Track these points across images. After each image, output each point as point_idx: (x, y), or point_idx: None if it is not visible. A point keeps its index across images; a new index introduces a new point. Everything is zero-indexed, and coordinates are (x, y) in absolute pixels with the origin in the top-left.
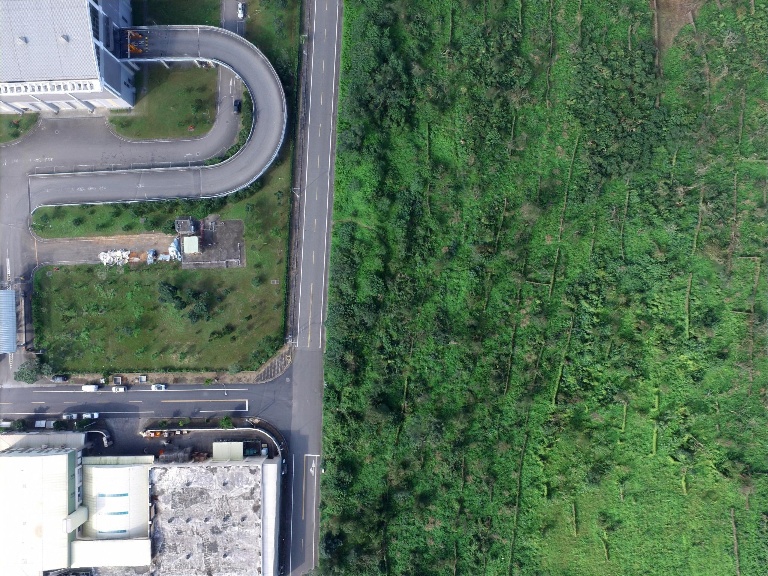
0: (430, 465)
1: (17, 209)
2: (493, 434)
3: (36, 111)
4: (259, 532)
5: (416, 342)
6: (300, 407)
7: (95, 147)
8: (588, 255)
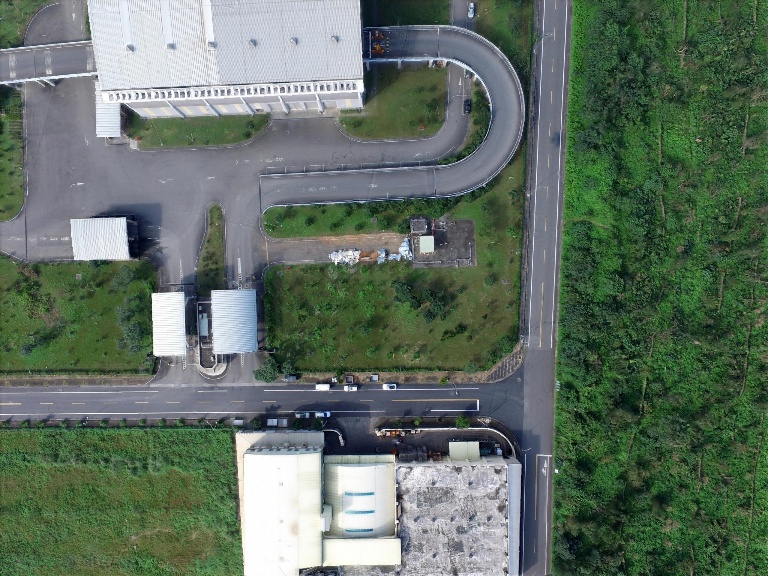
0: (666, 466)
1: (248, 209)
2: (727, 435)
3: (267, 112)
4: (505, 532)
5: (655, 342)
6: (532, 407)
7: (325, 147)
8: None
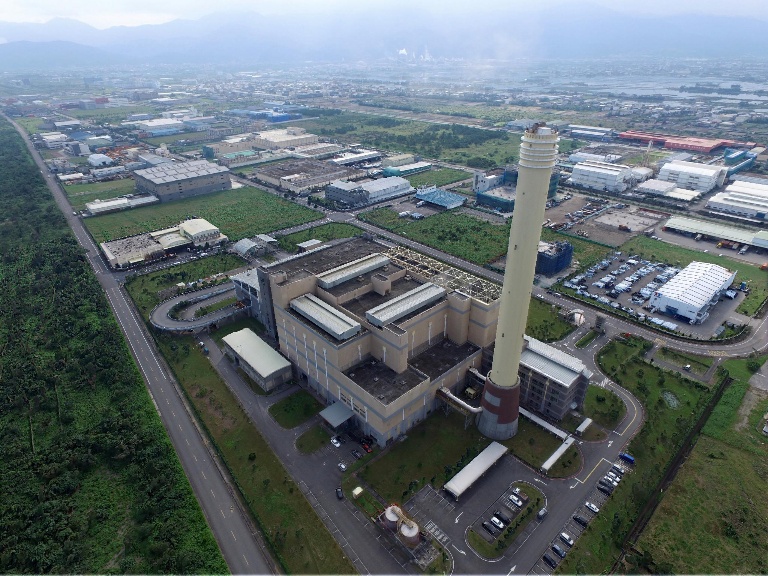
0: None
1: None
2: None
3: None
4: (111, 249)
5: None
6: None
7: None
8: None
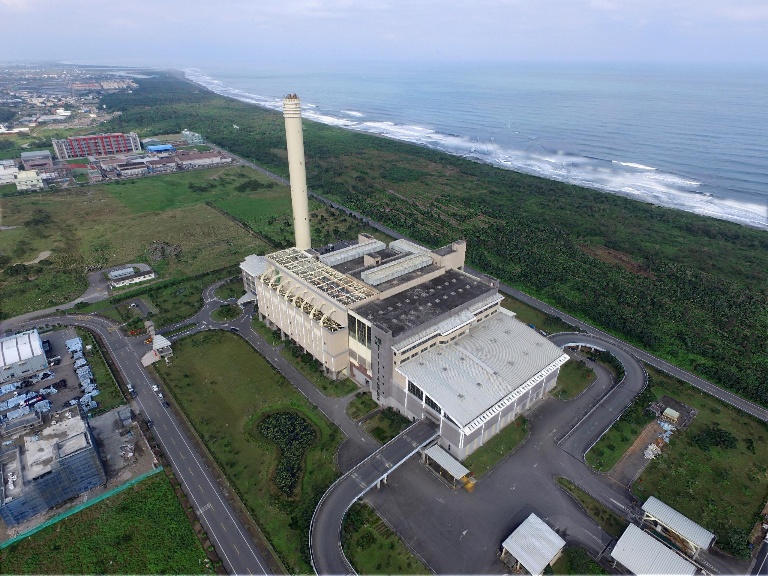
0: None
1: (575, 467)
2: None
3: (519, 414)
4: None
5: None
6: None
7: (565, 411)
8: (764, 330)
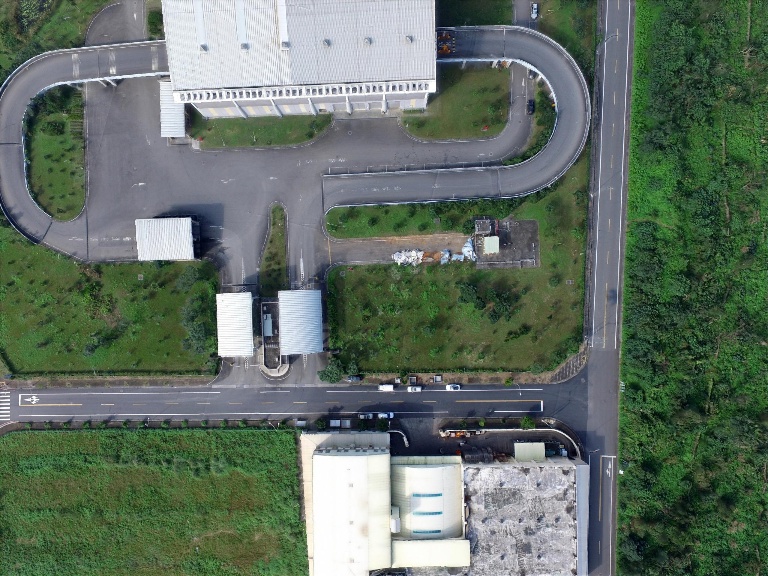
0: (731, 467)
1: (311, 209)
2: None
3: (330, 112)
4: (573, 533)
5: (721, 343)
6: (596, 408)
7: (388, 147)
8: None
